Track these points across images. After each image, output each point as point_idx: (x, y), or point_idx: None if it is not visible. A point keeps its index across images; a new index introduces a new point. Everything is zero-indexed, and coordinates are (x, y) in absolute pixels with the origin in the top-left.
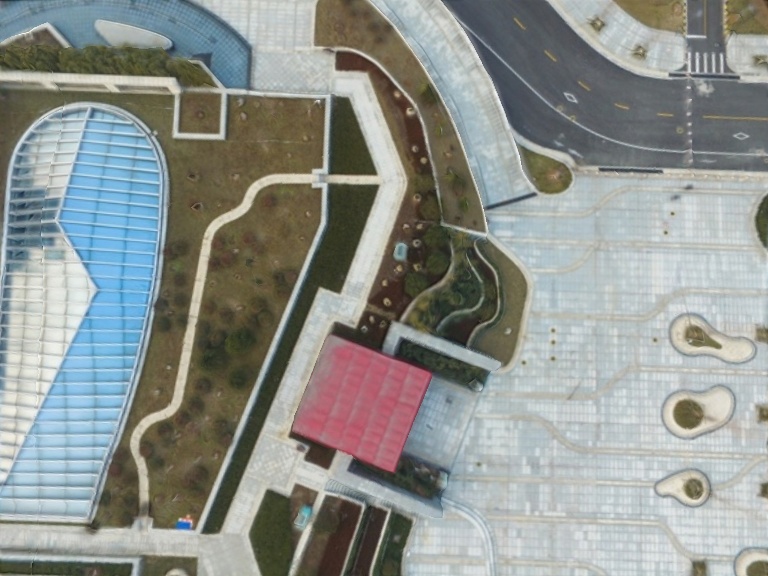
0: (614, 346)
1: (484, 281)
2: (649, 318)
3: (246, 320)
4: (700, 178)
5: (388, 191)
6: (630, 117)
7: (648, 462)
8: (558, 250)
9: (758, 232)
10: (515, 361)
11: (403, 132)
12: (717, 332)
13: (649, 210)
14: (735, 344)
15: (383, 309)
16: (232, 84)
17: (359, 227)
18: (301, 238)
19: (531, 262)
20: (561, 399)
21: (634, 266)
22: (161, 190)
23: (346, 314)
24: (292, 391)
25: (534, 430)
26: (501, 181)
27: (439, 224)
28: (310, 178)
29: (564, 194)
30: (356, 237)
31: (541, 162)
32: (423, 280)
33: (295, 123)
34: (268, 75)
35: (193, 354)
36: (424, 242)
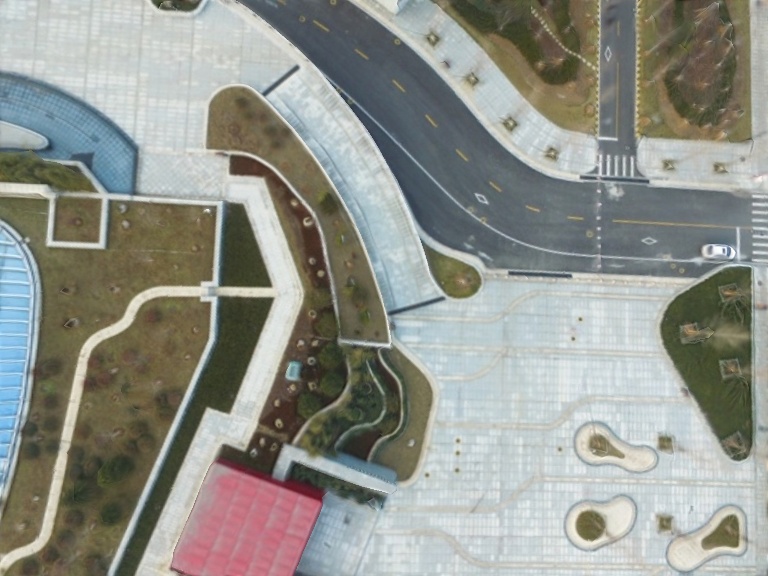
0: (519, 456)
1: (386, 393)
2: (554, 427)
3: (123, 447)
4: (608, 283)
5: (283, 304)
6: (541, 220)
7: (550, 575)
8: (465, 356)
9: (662, 340)
10: (418, 474)
11: (300, 242)
12: (621, 441)
13: (557, 315)
14: (638, 453)
15: (275, 431)
16: (116, 187)
17: (251, 343)
18: (186, 357)
19: (437, 369)
20: (464, 512)
21: (541, 373)
22: (32, 304)
23: (235, 436)
24: (175, 519)
25: (436, 545)
26: (408, 285)
27: (336, 341)
28: (199, 291)
29: (473, 298)
30: (248, 353)
31: (450, 265)
32: (317, 401)
33: (183, 231)
34: (156, 178)
35: (65, 482)
36: (319, 361)
